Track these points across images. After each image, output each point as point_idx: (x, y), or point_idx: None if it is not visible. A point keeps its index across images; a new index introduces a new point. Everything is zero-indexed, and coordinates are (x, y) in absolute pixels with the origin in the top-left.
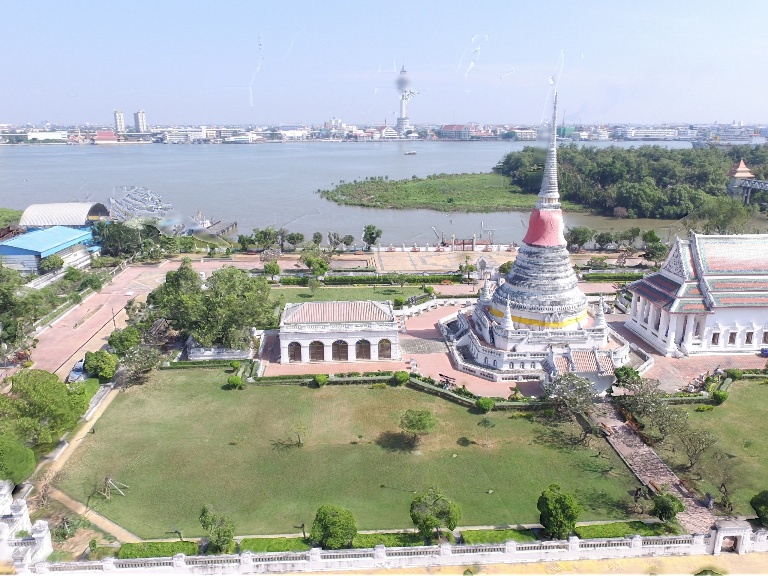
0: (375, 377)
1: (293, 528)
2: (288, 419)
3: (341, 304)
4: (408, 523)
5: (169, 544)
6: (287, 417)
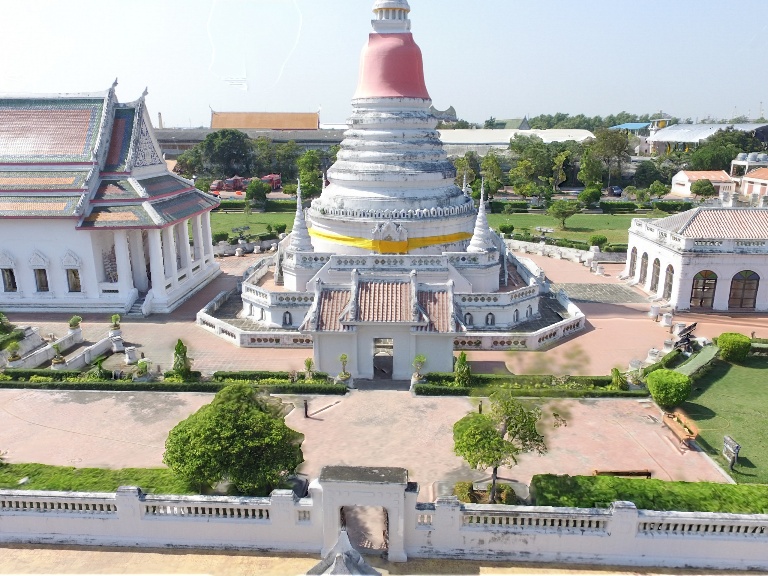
0: None
1: (618, 215)
2: None
3: None
4: None
5: (668, 202)
6: None
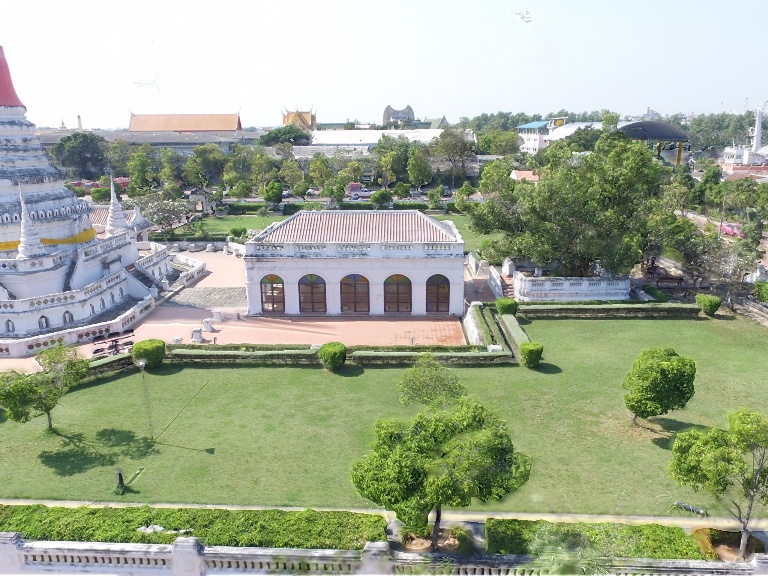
0: None
1: None
2: None
3: (356, 213)
4: None
5: None
6: None
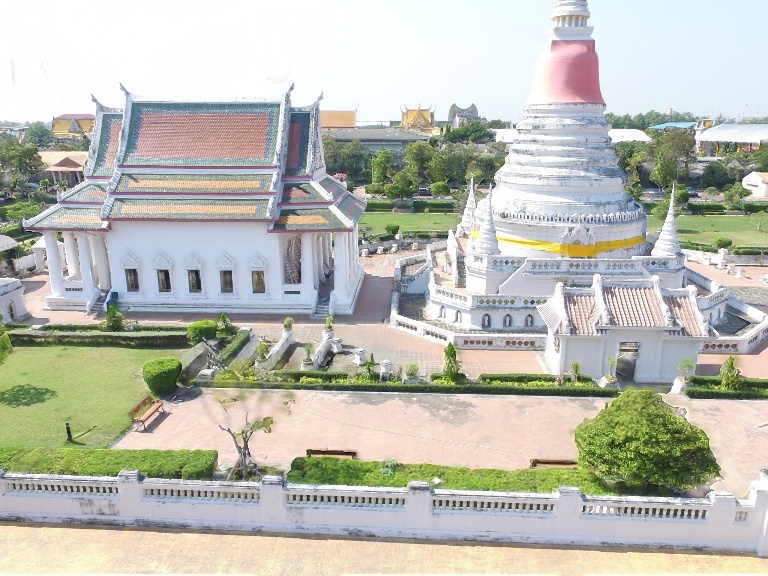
0: None
1: None
2: None
3: None
4: None
5: None
6: None
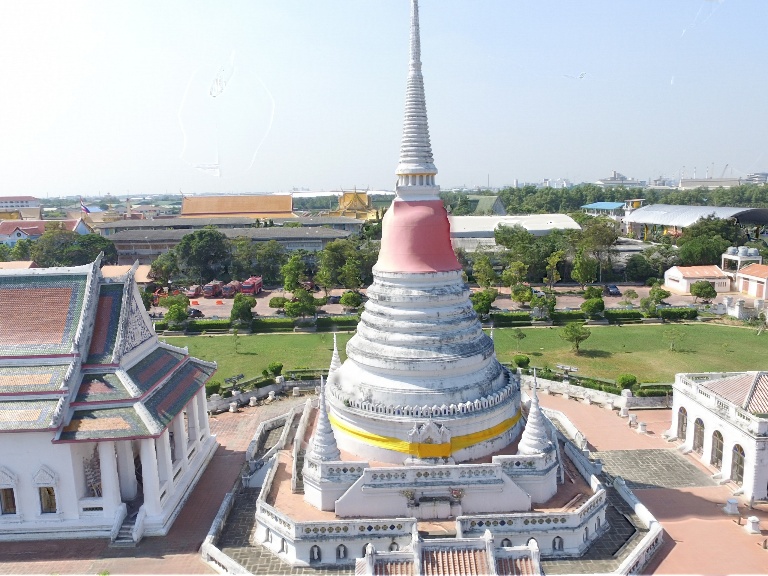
0: (663, 383)
1: None
2: (713, 364)
3: None
4: (561, 328)
5: None
6: (716, 365)
